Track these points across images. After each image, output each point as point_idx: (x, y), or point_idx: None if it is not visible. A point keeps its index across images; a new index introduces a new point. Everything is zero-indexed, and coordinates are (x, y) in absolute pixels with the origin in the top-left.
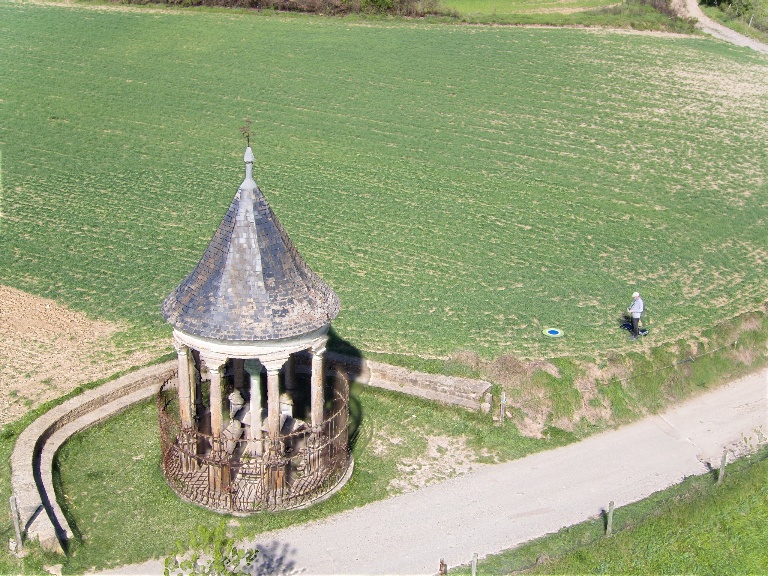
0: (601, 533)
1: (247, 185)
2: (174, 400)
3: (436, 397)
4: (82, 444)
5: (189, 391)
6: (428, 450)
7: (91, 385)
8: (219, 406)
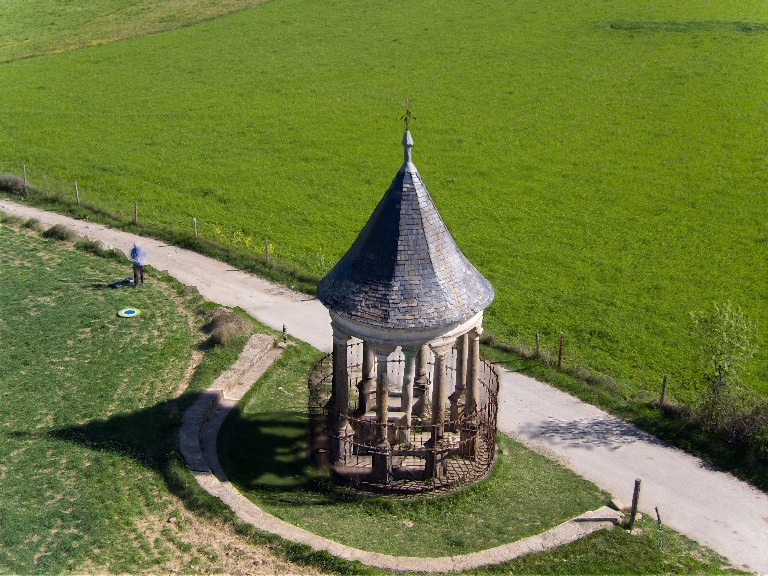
0: None
1: None
2: None
3: (265, 367)
4: None
5: None
6: None
7: (307, 546)
8: None
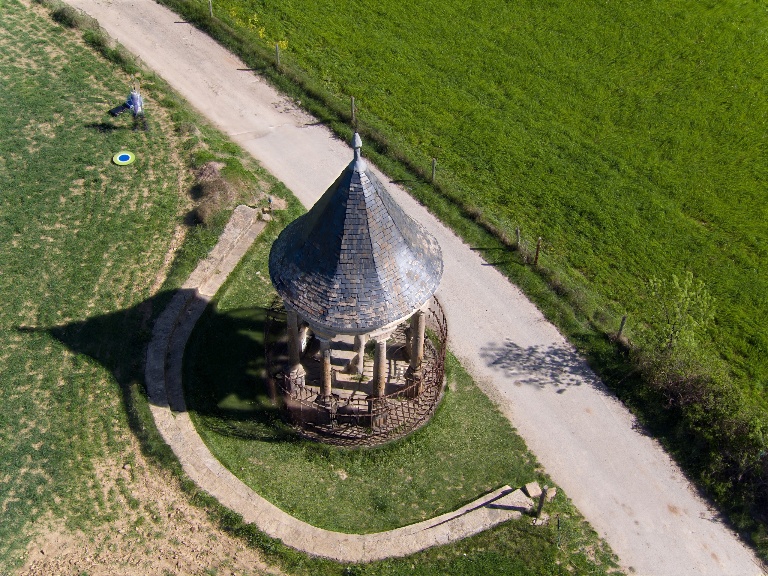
0: (427, 185)
1: (365, 165)
2: None
3: (245, 249)
4: None
5: None
6: None
7: (238, 517)
8: None
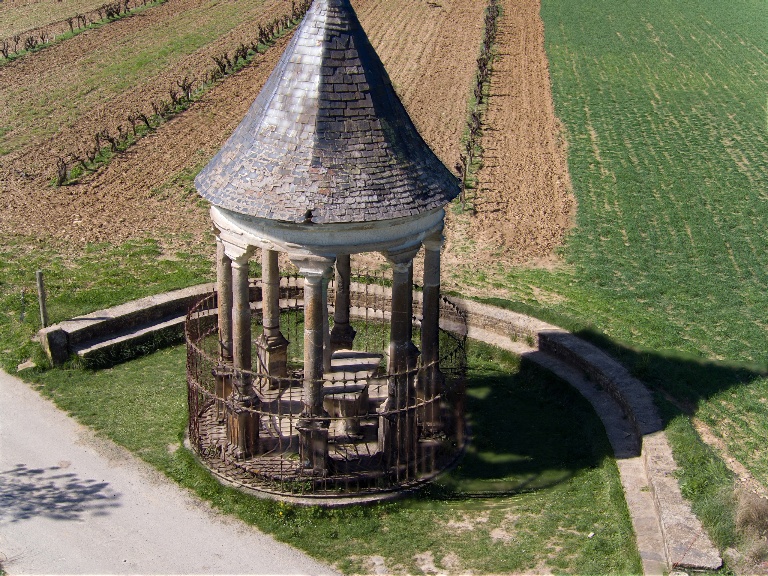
0: None
1: None
2: (445, 347)
3: (640, 529)
4: (298, 324)
5: (269, 276)
6: (503, 575)
7: (385, 281)
8: (221, 290)
